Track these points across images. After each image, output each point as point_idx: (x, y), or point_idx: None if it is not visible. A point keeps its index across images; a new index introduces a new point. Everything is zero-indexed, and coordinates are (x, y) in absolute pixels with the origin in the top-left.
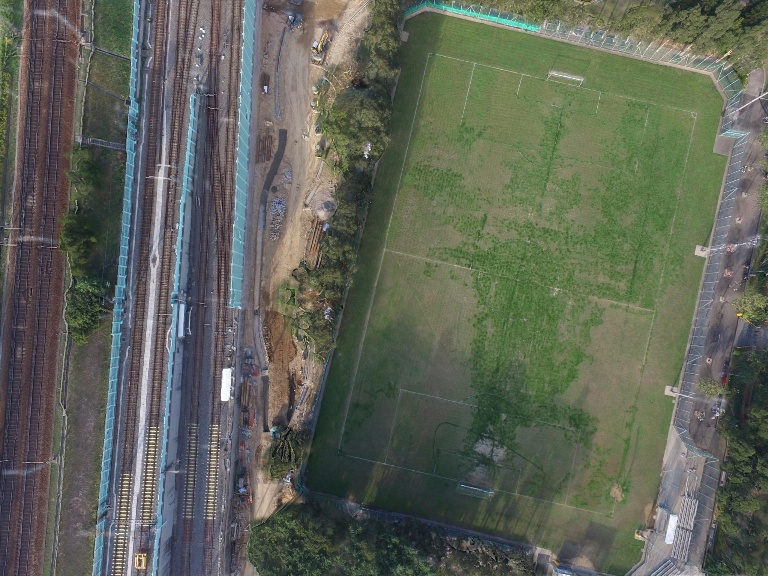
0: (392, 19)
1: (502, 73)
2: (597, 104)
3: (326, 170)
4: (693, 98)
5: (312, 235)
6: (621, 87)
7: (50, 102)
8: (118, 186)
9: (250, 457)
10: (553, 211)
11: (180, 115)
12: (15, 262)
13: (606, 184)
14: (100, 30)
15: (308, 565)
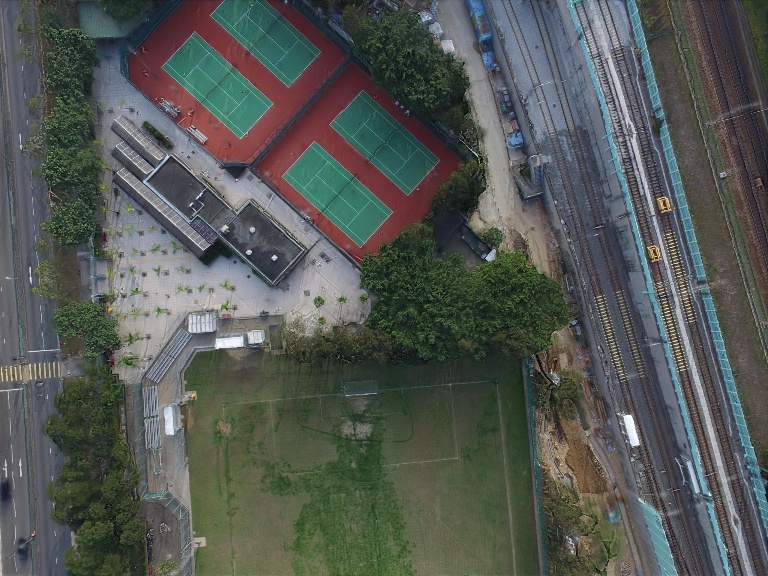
0: None
1: None
2: None
3: None
4: None
5: None
6: None
7: None
8: None
9: (576, 353)
10: None
11: None
12: None
13: None
14: None
15: None
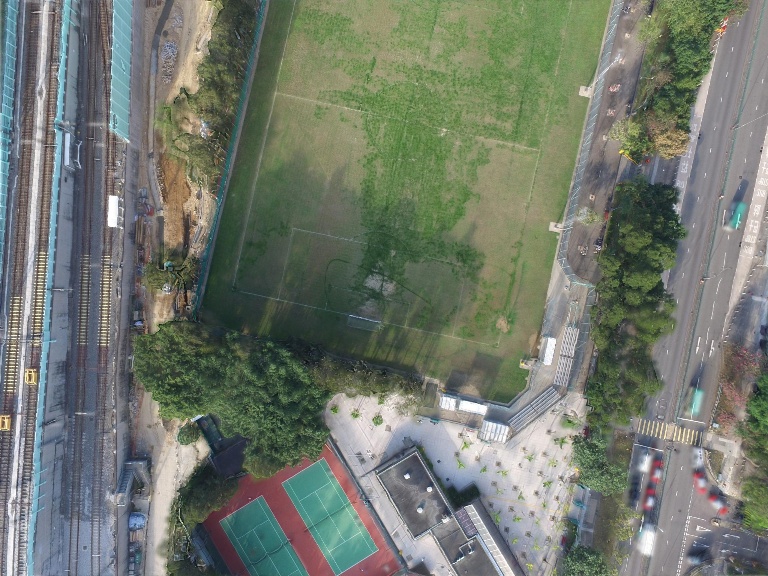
0: None
1: None
2: None
3: (216, 14)
4: None
5: (203, 78)
6: None
7: None
8: (2, 19)
9: (146, 293)
10: (441, 54)
11: None
12: None
13: (492, 27)
14: None
15: (185, 367)
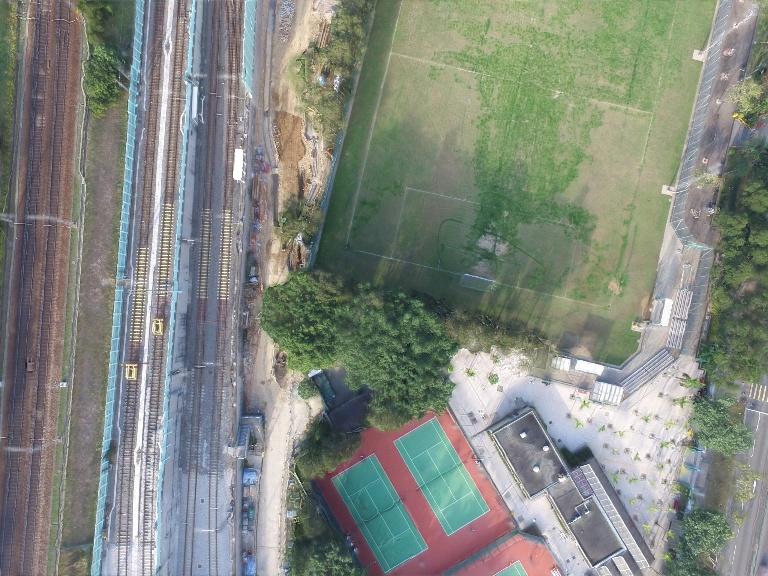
0: None
1: None
2: None
3: None
4: None
5: (320, 37)
6: None
7: None
8: None
9: (261, 250)
10: (555, 16)
11: None
12: (34, 34)
13: None
14: None
15: (319, 316)
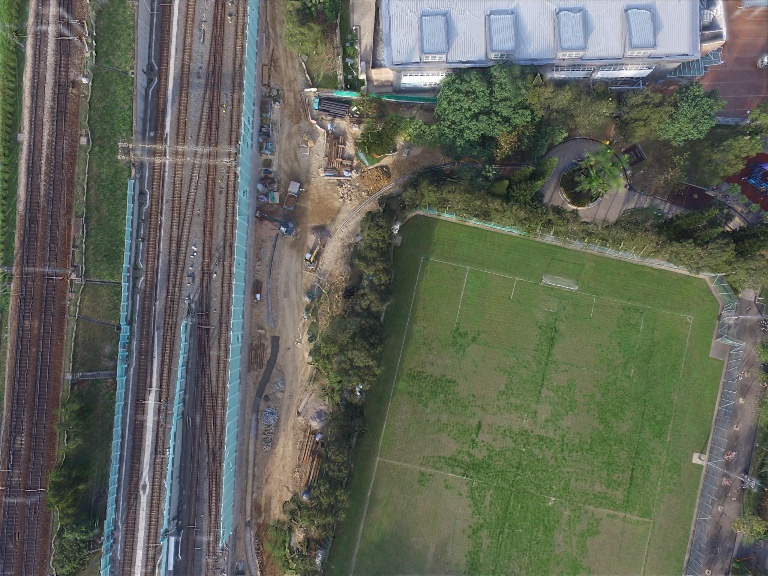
0: (384, 253)
1: (496, 277)
2: (592, 308)
3: (319, 378)
4: (689, 301)
5: (305, 445)
6: (616, 291)
7: (40, 340)
8: (108, 413)
9: None
10: (548, 418)
11: (171, 336)
12: (3, 506)
13: (602, 390)
14: (91, 261)
15: None
